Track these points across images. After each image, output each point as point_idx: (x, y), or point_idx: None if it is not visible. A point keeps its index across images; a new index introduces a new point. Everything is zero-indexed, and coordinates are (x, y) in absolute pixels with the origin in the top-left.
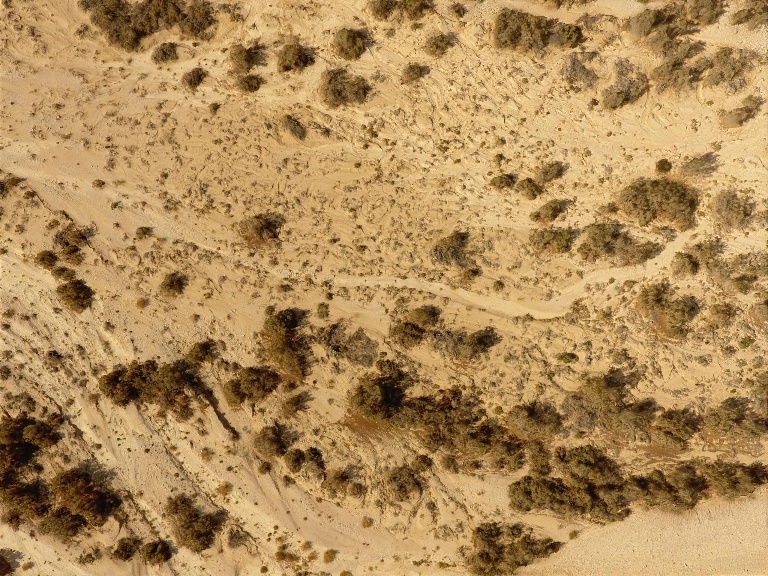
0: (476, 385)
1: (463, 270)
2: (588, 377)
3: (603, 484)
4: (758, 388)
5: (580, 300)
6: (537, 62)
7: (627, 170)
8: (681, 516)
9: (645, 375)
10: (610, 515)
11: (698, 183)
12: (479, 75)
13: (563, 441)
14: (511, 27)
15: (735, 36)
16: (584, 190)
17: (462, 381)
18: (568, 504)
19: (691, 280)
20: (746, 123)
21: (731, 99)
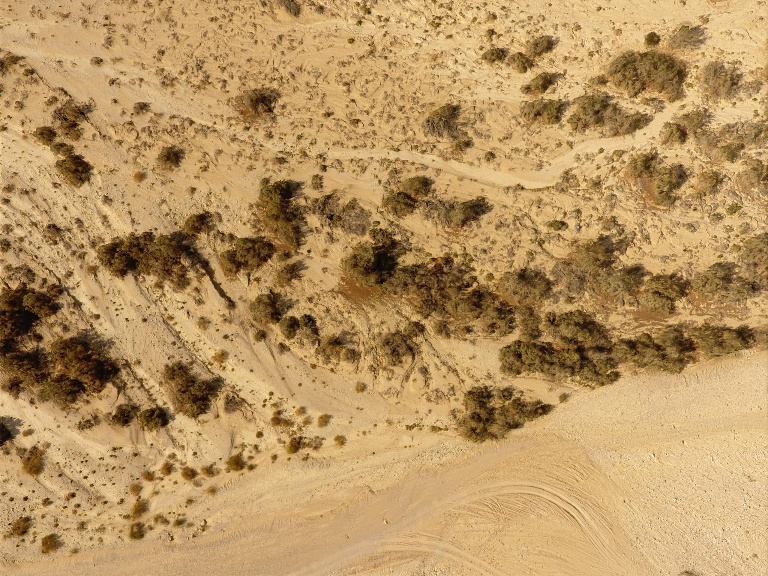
0: (467, 253)
1: (455, 142)
2: (578, 244)
3: (592, 346)
4: (745, 252)
5: (570, 170)
6: None
7: (616, 43)
8: (669, 380)
9: (634, 242)
10: (599, 376)
11: (686, 55)
12: None
13: (553, 306)
14: None
15: None
16: (574, 63)
17: (454, 249)
18: (558, 365)
19: (679, 149)
20: None
21: None
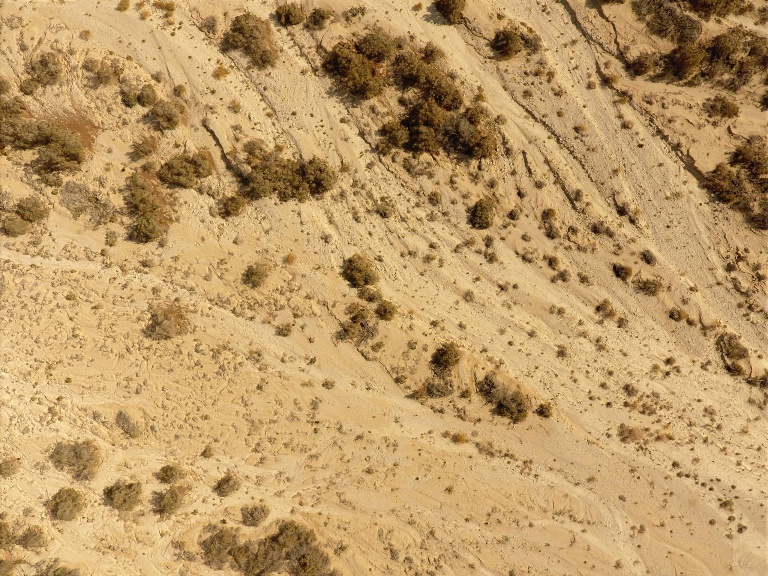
0: None
1: None
2: None
3: None
4: None
5: None
6: None
7: None
8: None
9: None
10: None
11: None
12: None
13: None
14: None
15: None
16: None
17: None
18: None
19: None
20: None
21: None
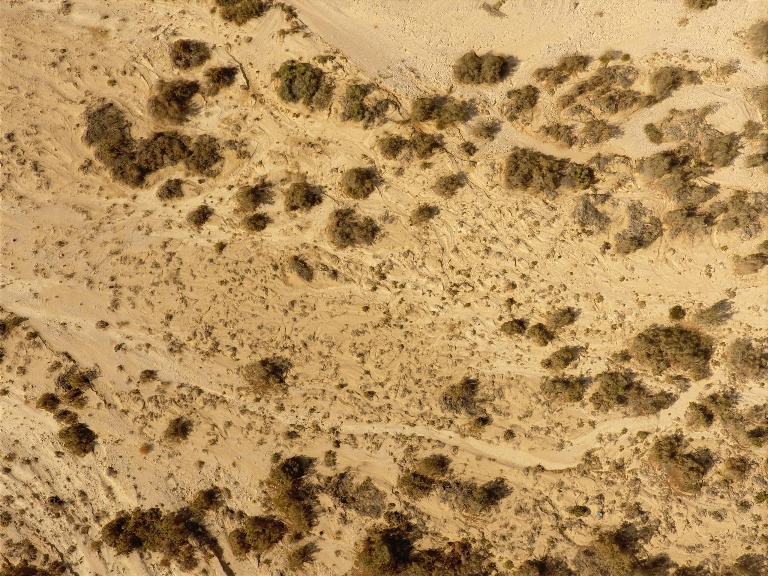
0: (486, 538)
1: (473, 418)
2: (600, 531)
3: None
4: None
5: (592, 451)
6: (548, 203)
7: (640, 316)
8: None
9: (658, 530)
10: None
11: (712, 331)
12: (489, 216)
13: None
14: (522, 170)
15: (750, 179)
16: (596, 336)
17: (472, 534)
18: None
19: (705, 431)
20: (761, 269)
21: (746, 244)
